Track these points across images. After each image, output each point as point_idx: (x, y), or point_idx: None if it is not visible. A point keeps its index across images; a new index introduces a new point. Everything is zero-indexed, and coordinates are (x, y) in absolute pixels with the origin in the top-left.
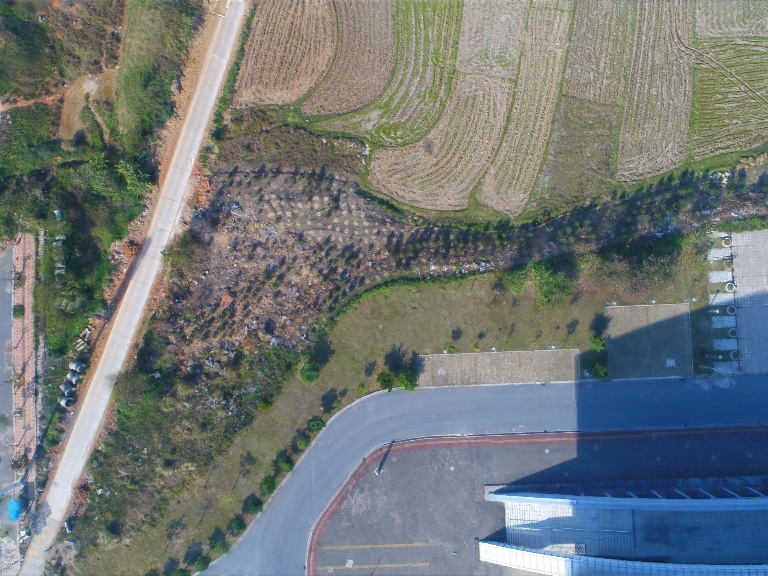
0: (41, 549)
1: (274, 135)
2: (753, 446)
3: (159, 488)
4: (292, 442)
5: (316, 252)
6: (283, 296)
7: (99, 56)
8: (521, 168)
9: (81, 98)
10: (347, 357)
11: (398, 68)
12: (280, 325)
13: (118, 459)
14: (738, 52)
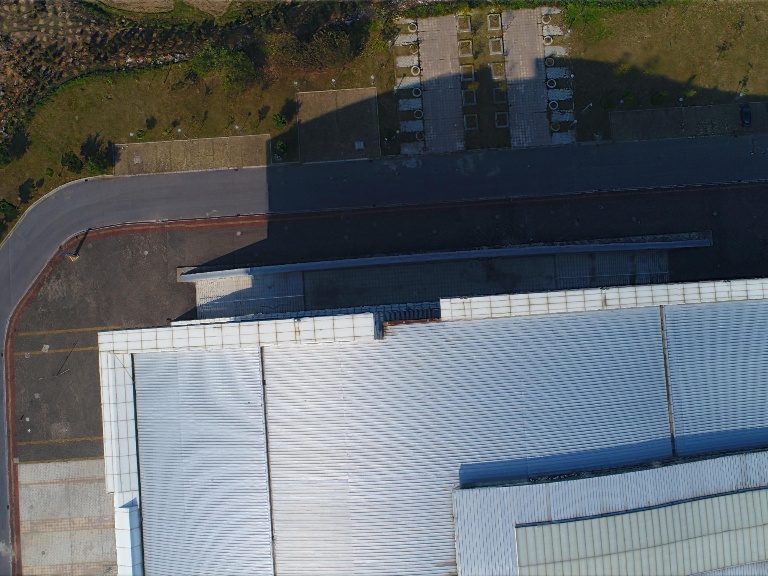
0: None
1: None
2: (438, 222)
3: None
4: None
5: (20, 52)
6: None
7: None
8: None
9: None
10: (44, 148)
11: None
12: None
13: None
14: None
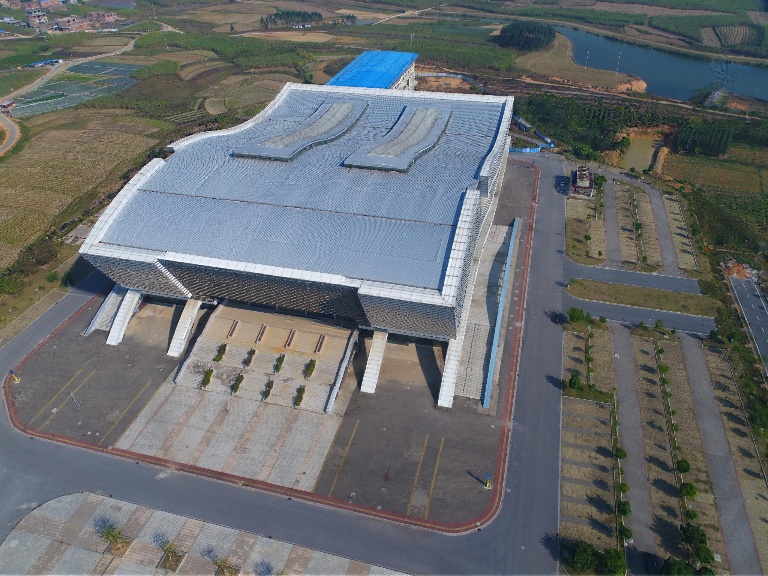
0: None
1: None
2: None
3: None
4: None
5: None
6: None
7: None
8: None
9: None
10: None
11: None
12: None
13: None
14: (4, 226)
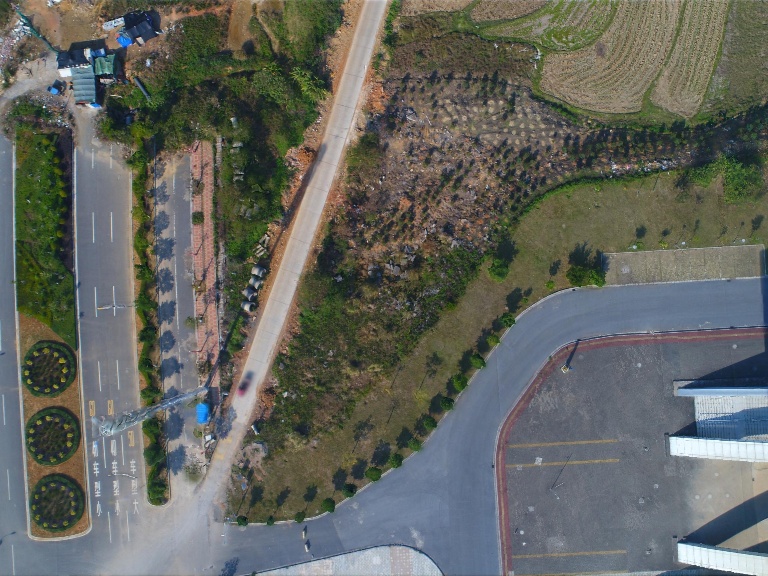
0: (227, 453)
1: (446, 41)
2: None
3: (346, 389)
4: (478, 342)
5: (493, 155)
6: (461, 200)
7: None
8: (695, 69)
9: (248, 9)
10: (531, 257)
11: None
12: (460, 228)
13: (304, 361)
14: None
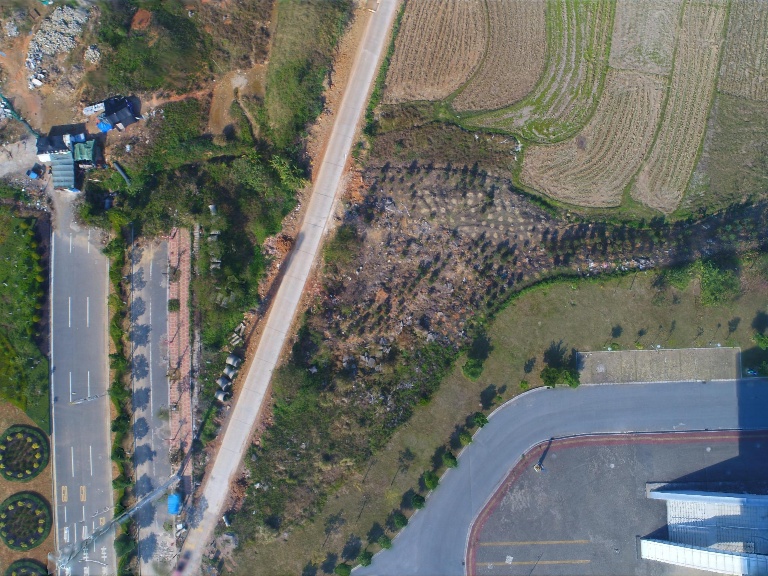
0: (198, 543)
1: (426, 131)
2: None
3: (318, 483)
4: (451, 438)
5: (471, 248)
6: (437, 292)
7: (249, 51)
8: (675, 165)
9: (230, 93)
10: (506, 354)
11: (550, 64)
12: (436, 321)
13: (276, 454)
14: None
